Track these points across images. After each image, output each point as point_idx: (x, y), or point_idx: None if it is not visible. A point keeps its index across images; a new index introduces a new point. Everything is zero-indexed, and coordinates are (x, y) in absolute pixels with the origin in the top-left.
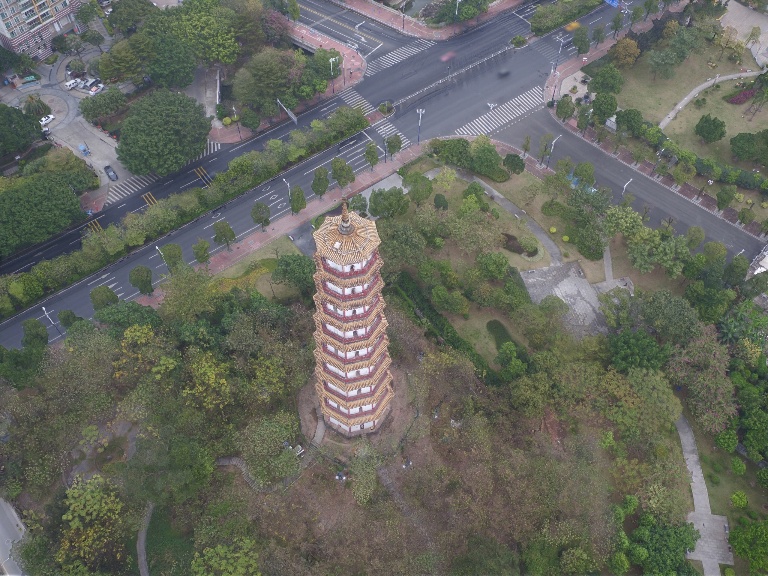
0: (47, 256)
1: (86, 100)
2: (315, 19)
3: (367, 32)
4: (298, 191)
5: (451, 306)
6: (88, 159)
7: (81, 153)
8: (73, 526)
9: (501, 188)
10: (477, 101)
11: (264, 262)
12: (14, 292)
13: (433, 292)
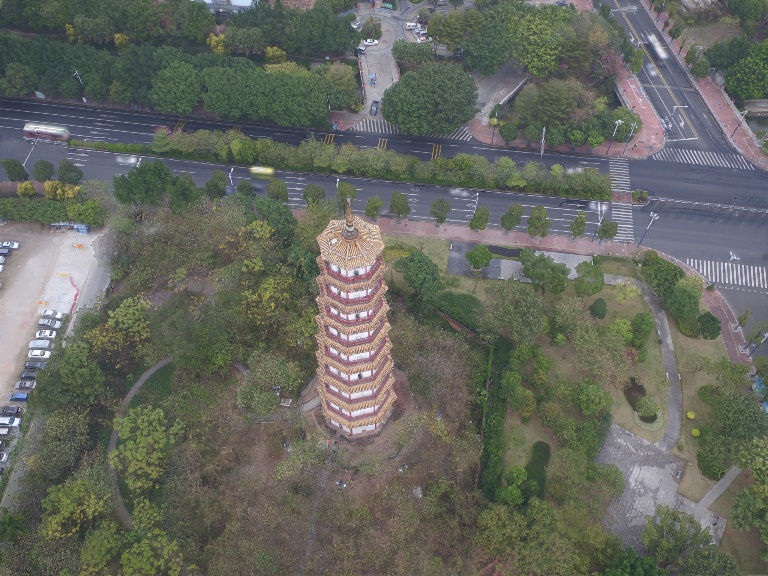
0: (281, 139)
1: (401, 42)
2: (655, 81)
3: (693, 120)
4: (484, 212)
5: (511, 398)
6: (370, 88)
7: (369, 80)
8: (109, 322)
9: (679, 340)
10: (740, 247)
11: (412, 249)
12: (232, 147)
13: (507, 374)
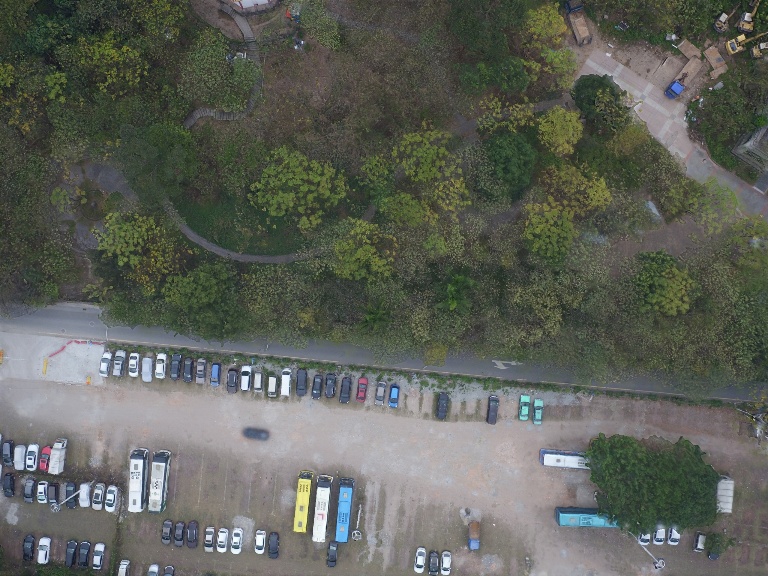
0: None
1: None
2: None
3: None
4: None
5: None
6: None
7: None
8: (135, 263)
9: None
10: None
11: None
12: None
13: None
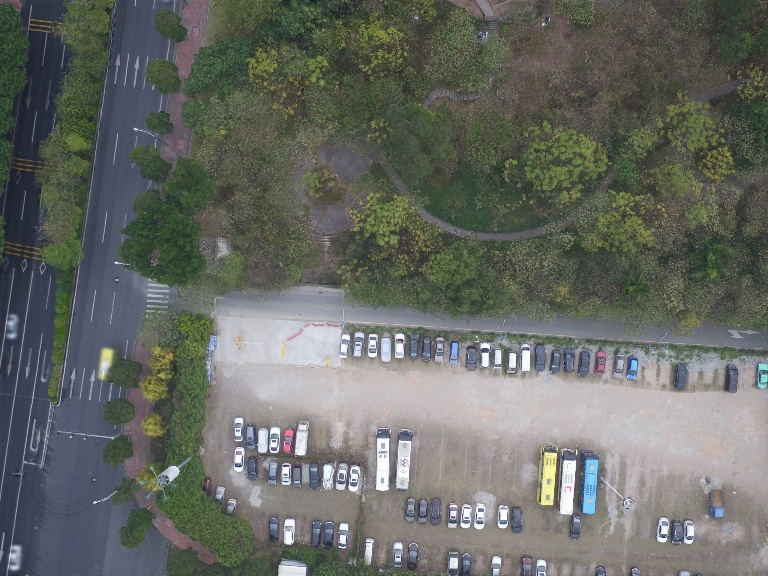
0: (39, 96)
1: None
2: None
3: None
4: None
5: None
6: None
7: None
8: (394, 242)
9: None
10: None
11: None
12: (77, 147)
13: None
